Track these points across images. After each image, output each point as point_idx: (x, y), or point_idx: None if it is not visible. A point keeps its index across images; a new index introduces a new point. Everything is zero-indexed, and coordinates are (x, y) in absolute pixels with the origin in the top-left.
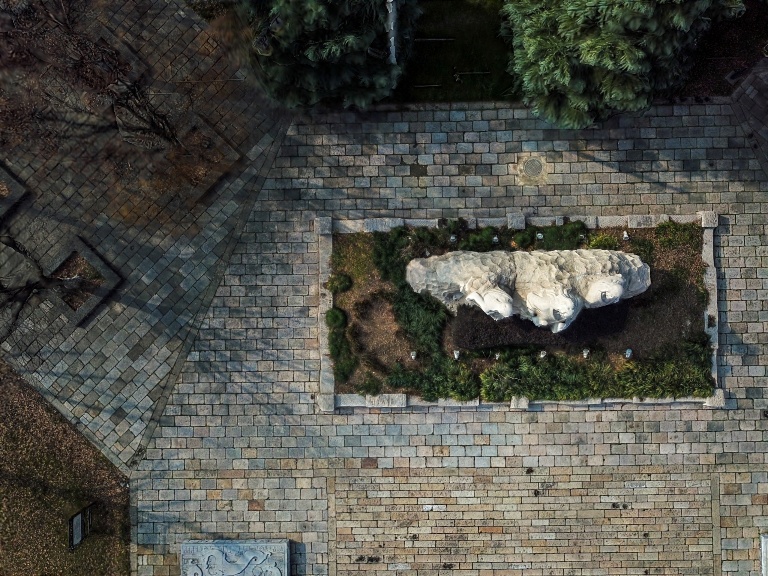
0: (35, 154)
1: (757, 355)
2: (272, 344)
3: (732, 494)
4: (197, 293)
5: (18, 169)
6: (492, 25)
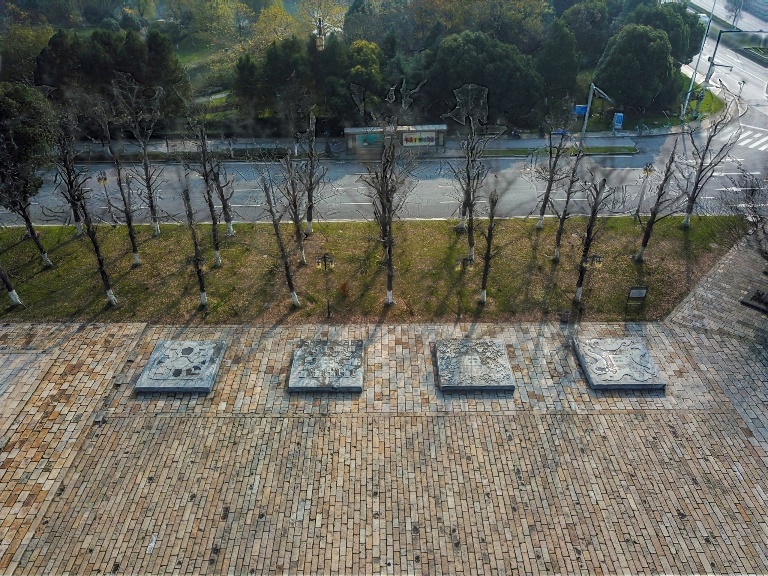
0: None
1: None
2: None
3: None
4: None
5: None
6: None
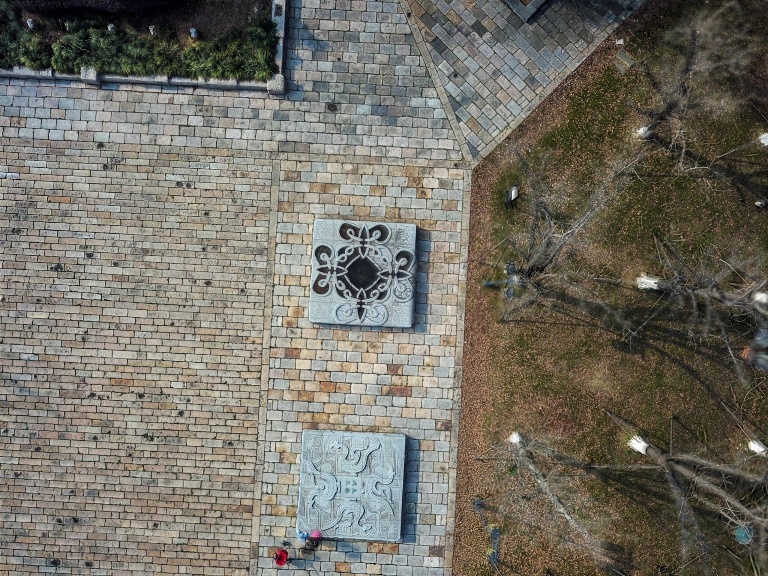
0: None
1: (327, 51)
2: None
3: (291, 181)
4: None
5: None
6: None
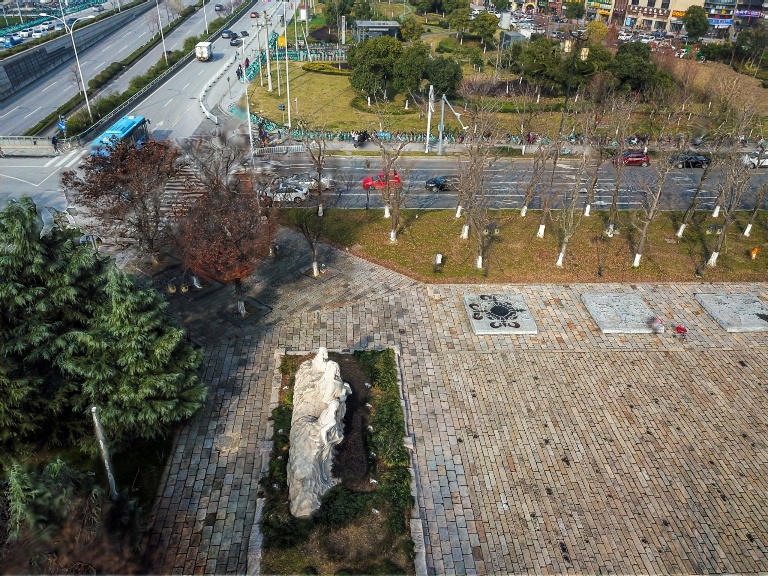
0: None
1: (367, 337)
2: None
3: (454, 346)
4: None
5: None
6: (100, 464)
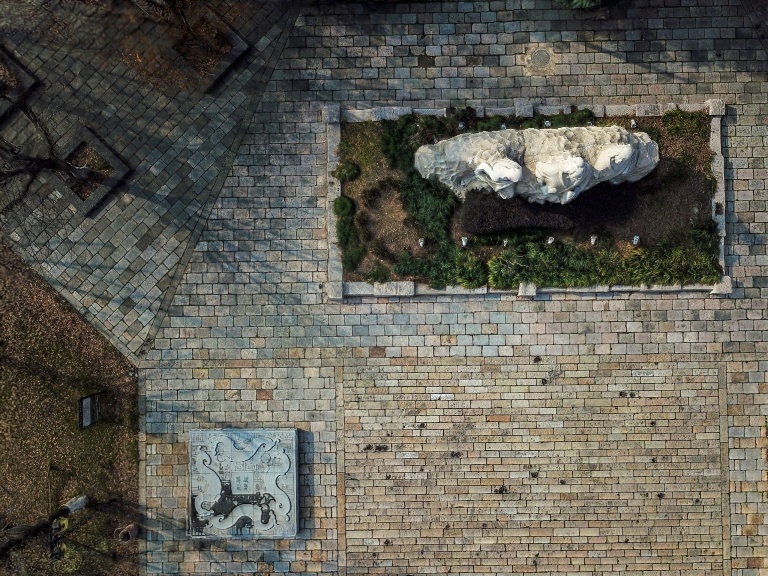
0: (44, 46)
1: (764, 245)
2: (280, 234)
3: (739, 383)
4: (205, 184)
5: (27, 61)
6: None
